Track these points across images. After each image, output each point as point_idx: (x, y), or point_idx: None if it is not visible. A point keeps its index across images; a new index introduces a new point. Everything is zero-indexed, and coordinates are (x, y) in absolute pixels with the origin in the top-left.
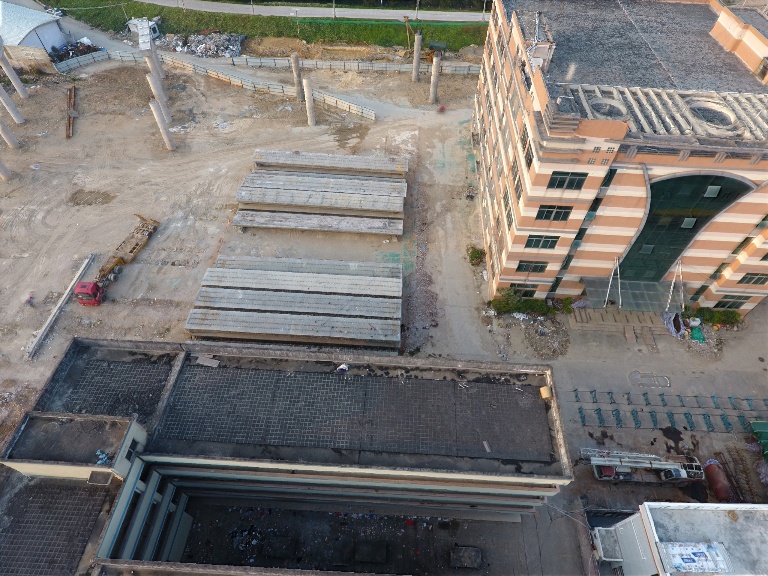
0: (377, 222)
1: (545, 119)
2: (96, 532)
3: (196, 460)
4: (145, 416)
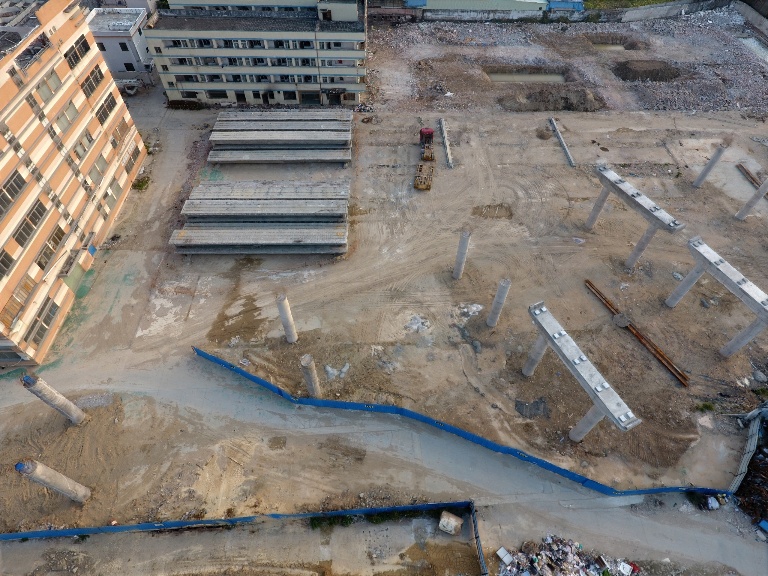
0: None
1: None
2: None
3: (298, 15)
4: None
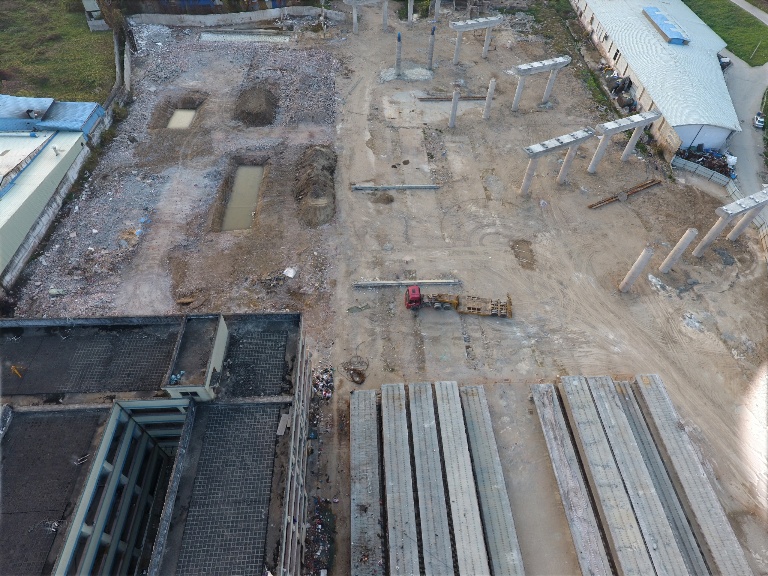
0: None
1: None
2: (143, 393)
3: None
4: (232, 391)
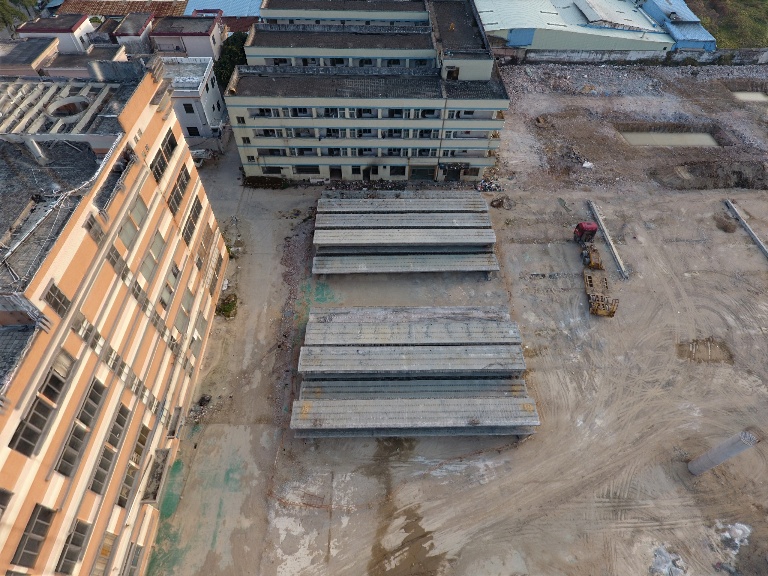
0: (340, 321)
1: (160, 76)
2: None
3: (414, 72)
4: None
